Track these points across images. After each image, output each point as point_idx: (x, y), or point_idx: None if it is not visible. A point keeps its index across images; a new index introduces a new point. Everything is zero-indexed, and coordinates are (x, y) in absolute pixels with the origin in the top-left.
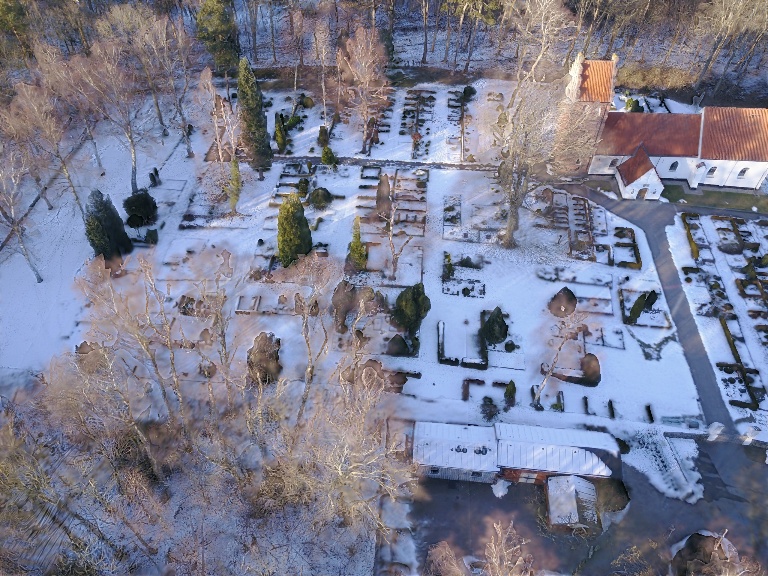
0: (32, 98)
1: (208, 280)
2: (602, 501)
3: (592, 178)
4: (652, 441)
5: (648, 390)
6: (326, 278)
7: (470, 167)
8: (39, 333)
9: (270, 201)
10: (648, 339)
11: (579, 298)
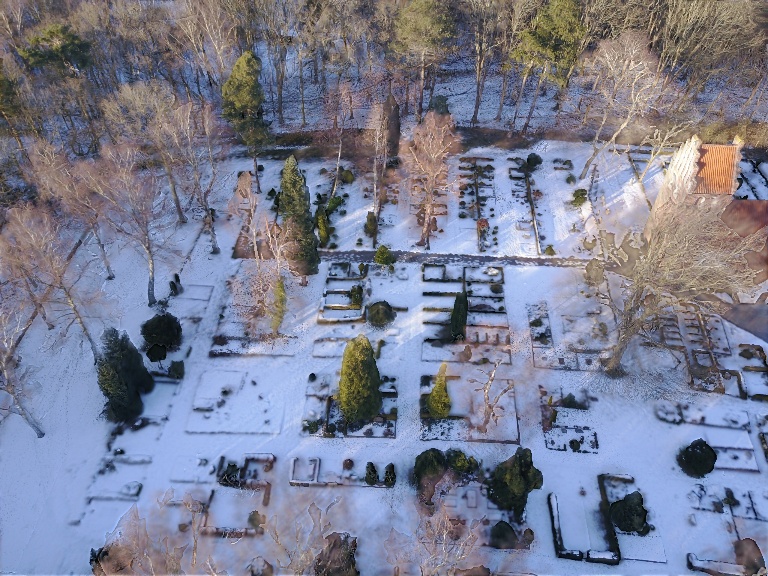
0: (27, 227)
1: (251, 433)
2: None
3: None
4: None
5: None
6: None
7: (550, 262)
8: (42, 515)
9: (318, 317)
10: None
11: (713, 448)
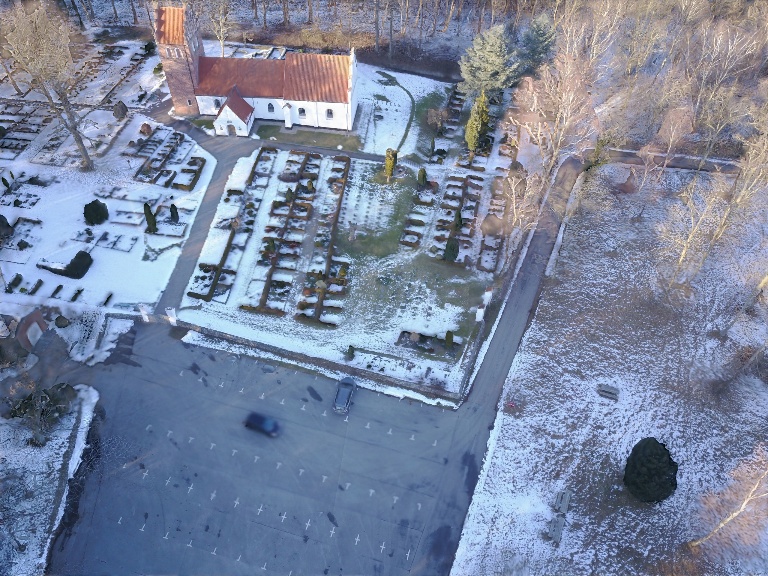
0: None
1: None
2: (1, 358)
3: (203, 118)
4: (94, 320)
5: (124, 283)
6: None
7: (104, 108)
8: None
9: None
10: (157, 245)
11: (119, 212)
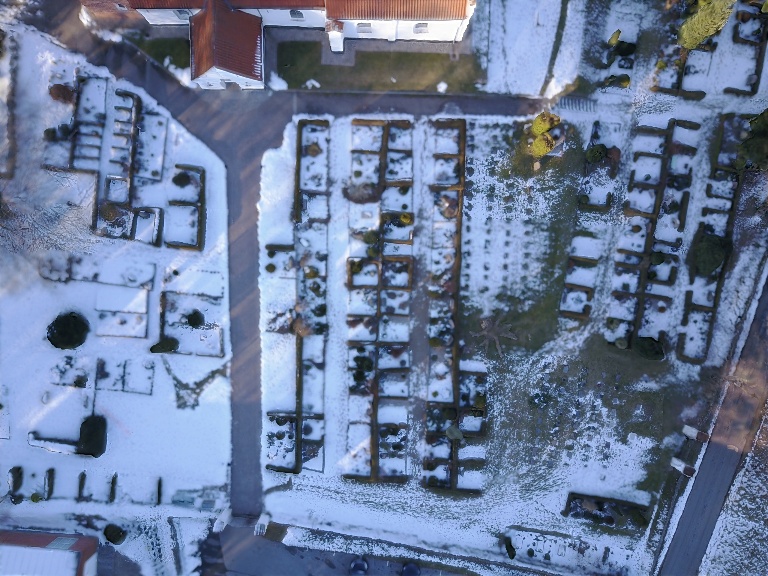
0: None
1: None
2: None
3: (158, 32)
4: (155, 525)
5: (169, 454)
6: None
7: None
8: None
9: None
10: (188, 375)
11: (100, 311)
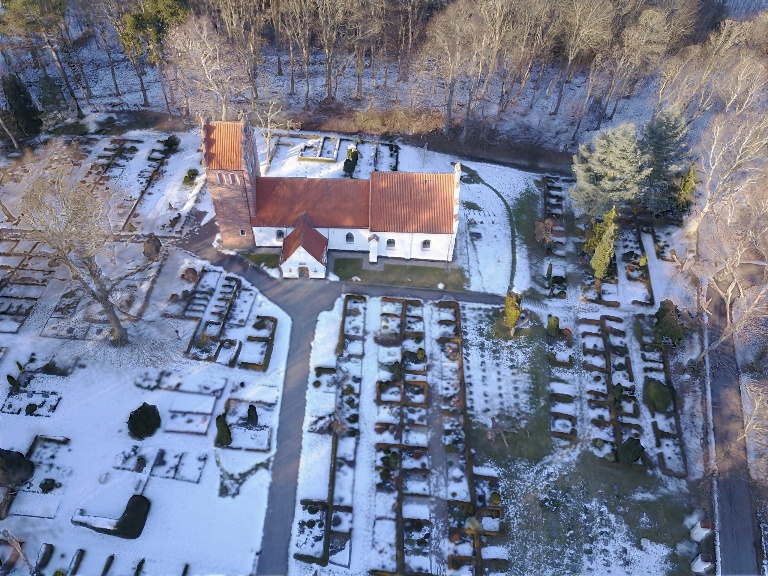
0: None
1: None
2: None
3: (260, 251)
4: None
5: (201, 541)
6: None
7: (127, 238)
8: None
9: None
10: (234, 467)
11: (173, 412)
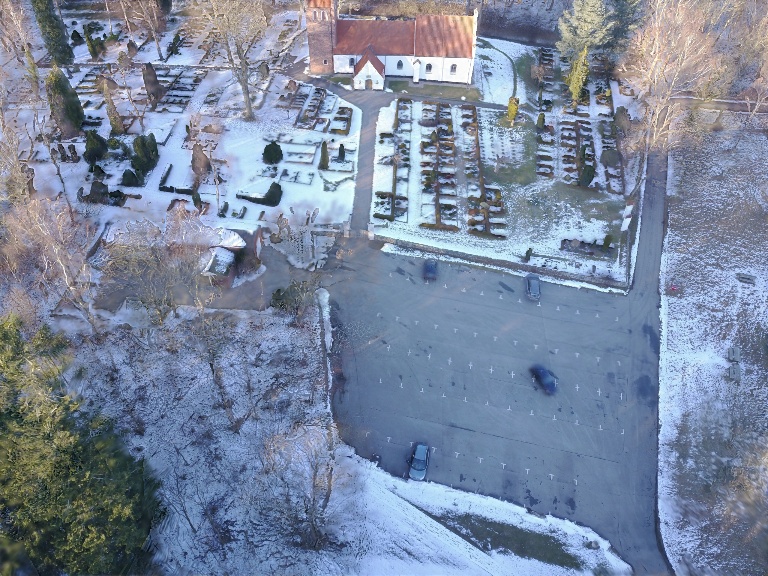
0: None
1: None
2: (239, 265)
3: (337, 76)
4: (301, 237)
5: None
6: (2, 82)
7: None
8: None
9: None
10: (332, 179)
11: (290, 153)
